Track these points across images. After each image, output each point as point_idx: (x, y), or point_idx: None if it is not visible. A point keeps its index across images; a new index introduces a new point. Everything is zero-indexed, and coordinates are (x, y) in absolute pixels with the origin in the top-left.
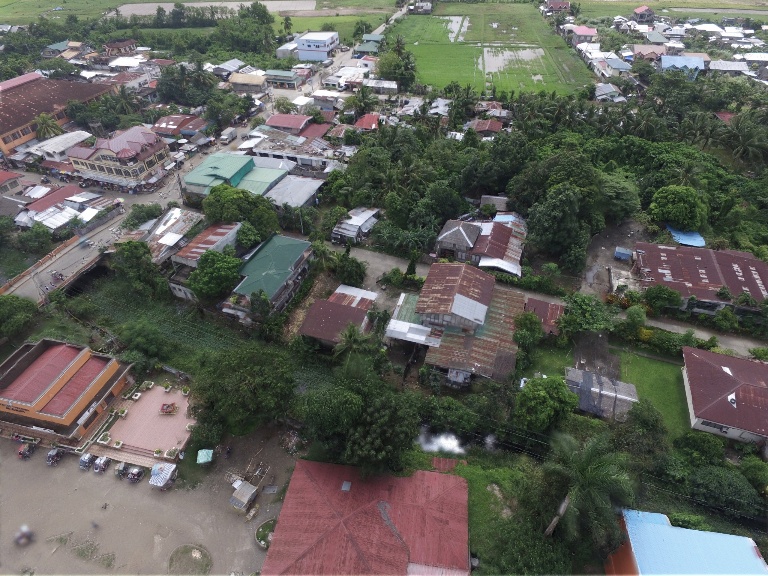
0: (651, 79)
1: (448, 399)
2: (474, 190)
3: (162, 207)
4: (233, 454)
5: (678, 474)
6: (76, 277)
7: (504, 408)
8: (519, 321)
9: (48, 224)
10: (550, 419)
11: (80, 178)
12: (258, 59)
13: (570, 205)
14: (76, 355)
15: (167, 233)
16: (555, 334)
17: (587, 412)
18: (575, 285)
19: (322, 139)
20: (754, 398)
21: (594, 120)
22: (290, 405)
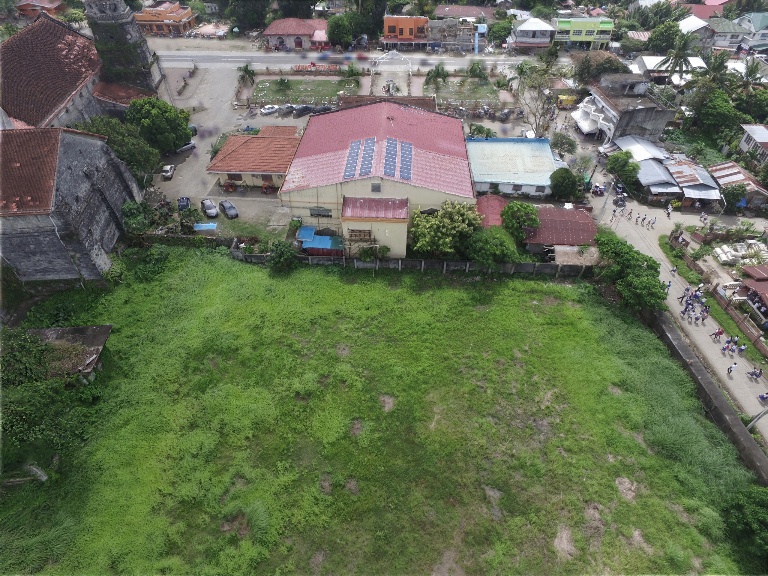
0: None
1: None
2: None
3: None
4: None
5: None
6: None
7: None
8: None
9: None
10: None
11: None
12: None
13: None
14: None
15: None
16: None
17: None
18: None
19: None
20: (455, 8)
21: None
22: None
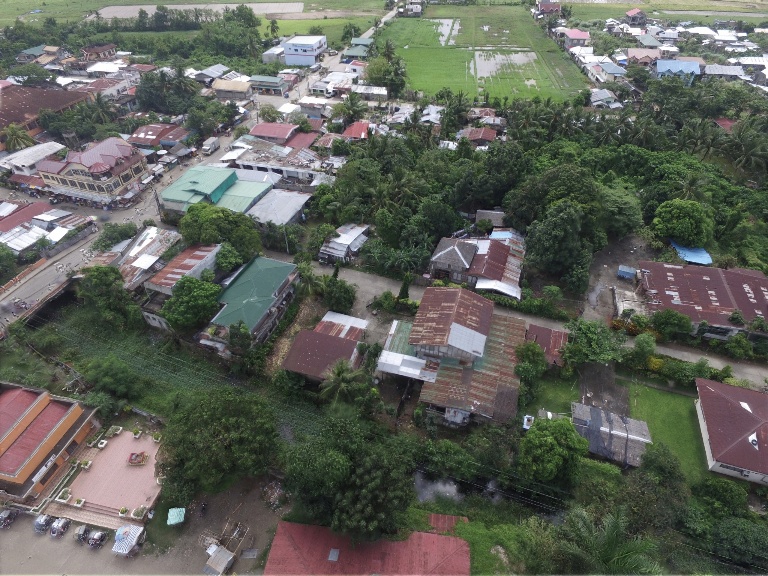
0: (648, 85)
1: (446, 443)
2: (469, 203)
3: (137, 225)
4: (209, 511)
5: (699, 527)
6: (41, 305)
7: (506, 450)
8: (520, 352)
9: (13, 246)
10: (558, 468)
11: (51, 193)
12: (243, 64)
13: (572, 223)
14: (33, 400)
15: (142, 255)
16: (559, 365)
17: (597, 455)
18: (578, 307)
19: (309, 149)
20: None
21: (591, 128)
22: (273, 451)
